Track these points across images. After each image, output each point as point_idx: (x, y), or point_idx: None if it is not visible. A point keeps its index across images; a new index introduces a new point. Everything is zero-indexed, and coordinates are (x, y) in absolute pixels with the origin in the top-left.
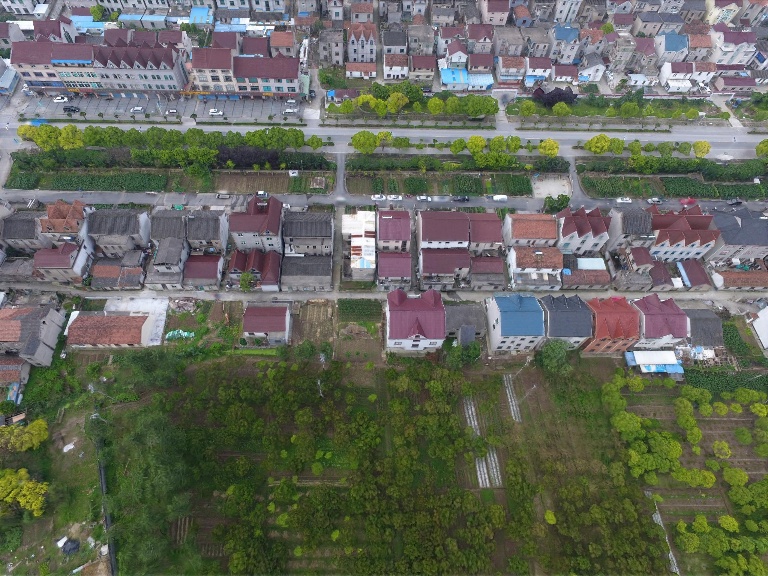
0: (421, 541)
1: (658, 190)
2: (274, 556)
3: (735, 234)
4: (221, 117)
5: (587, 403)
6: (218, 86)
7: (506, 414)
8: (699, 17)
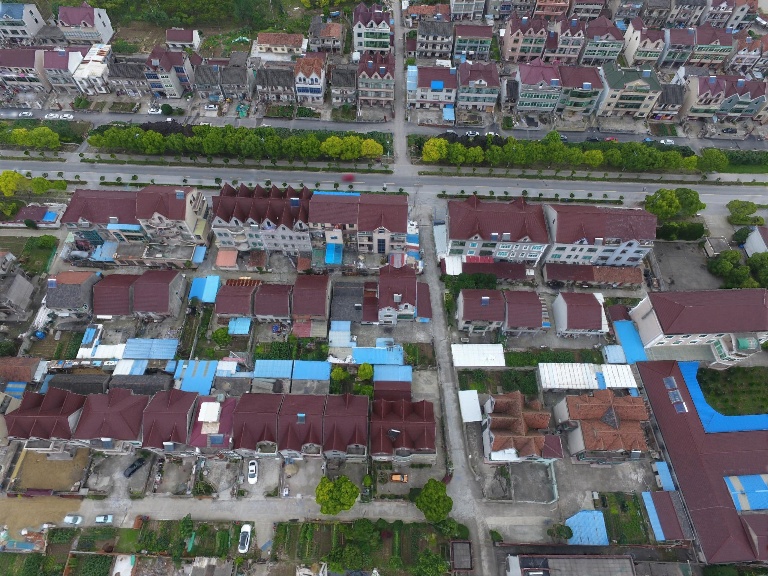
0: None
1: None
2: None
3: None
4: None
5: None
6: None
7: None
8: None
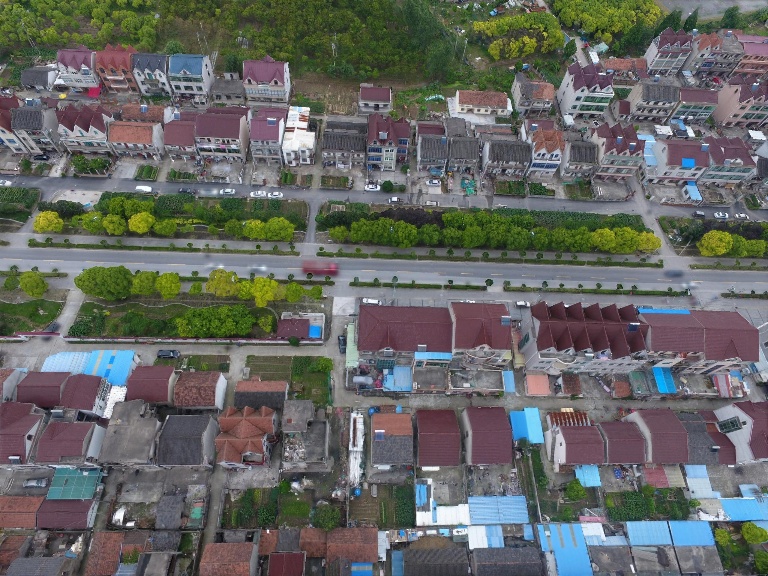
0: None
1: None
2: None
3: None
4: (460, 300)
5: None
6: None
7: None
8: None
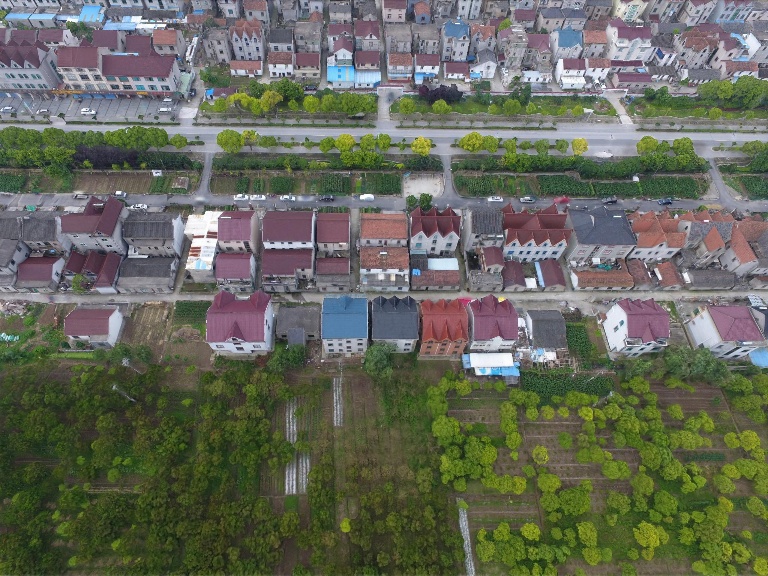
0: (202, 550)
1: (533, 189)
2: (42, 566)
3: (588, 233)
4: None
5: (413, 407)
6: (89, 85)
7: (328, 418)
8: (607, 13)
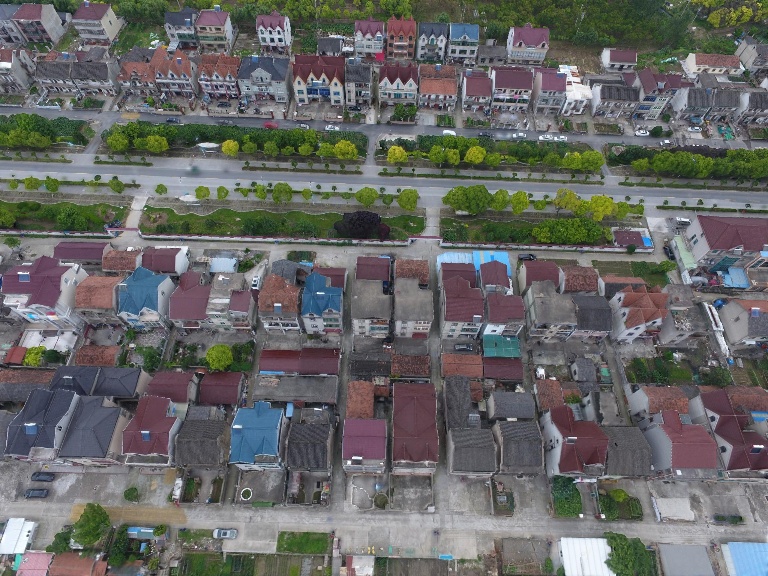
0: None
1: None
2: None
3: None
4: None
5: None
6: None
7: None
8: None
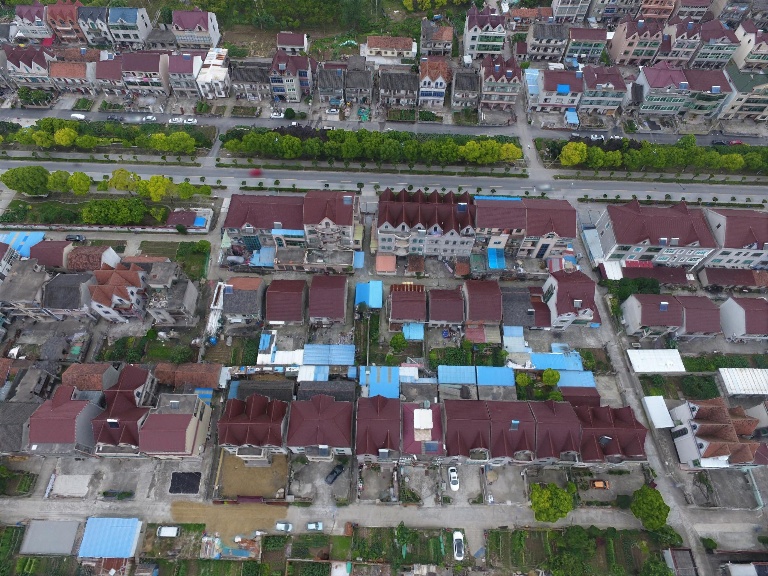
0: None
1: None
2: None
3: None
4: None
5: None
6: None
7: None
8: None
